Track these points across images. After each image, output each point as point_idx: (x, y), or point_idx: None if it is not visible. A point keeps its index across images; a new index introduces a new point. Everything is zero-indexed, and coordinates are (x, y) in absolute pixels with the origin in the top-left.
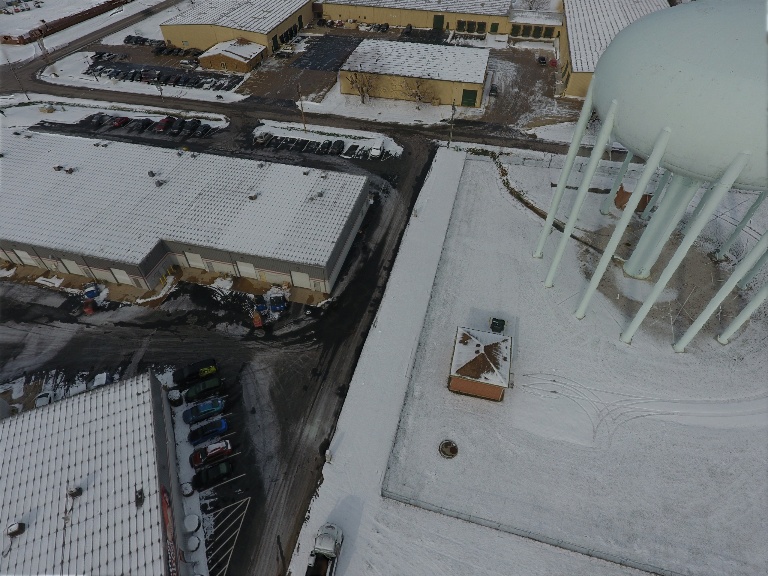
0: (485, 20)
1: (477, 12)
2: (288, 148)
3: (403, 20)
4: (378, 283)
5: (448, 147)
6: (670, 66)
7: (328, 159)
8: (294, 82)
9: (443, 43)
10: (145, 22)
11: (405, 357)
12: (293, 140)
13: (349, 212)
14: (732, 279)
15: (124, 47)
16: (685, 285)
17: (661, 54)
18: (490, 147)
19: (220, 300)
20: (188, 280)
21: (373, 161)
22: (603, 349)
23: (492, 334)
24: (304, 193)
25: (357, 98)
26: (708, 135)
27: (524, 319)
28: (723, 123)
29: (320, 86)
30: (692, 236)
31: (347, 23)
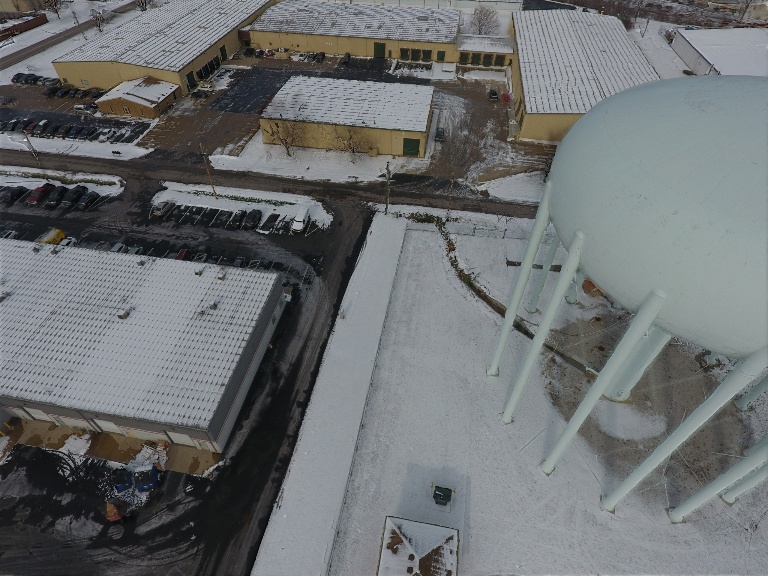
0: (430, 48)
1: (421, 39)
2: (192, 222)
3: (341, 48)
4: (288, 430)
5: (386, 213)
6: (659, 200)
7: (240, 236)
8: (210, 129)
9: (385, 75)
10: (44, 54)
11: (316, 561)
12: (200, 210)
13: (249, 332)
14: (749, 463)
15: (11, 87)
16: (674, 408)
17: (644, 178)
18: (435, 211)
19: (68, 475)
20: (28, 442)
21: (295, 237)
22: (580, 525)
23: (432, 528)
24: (193, 304)
25: (282, 149)
26: (723, 311)
27: (477, 479)
28: (746, 298)
29: (240, 134)
30: (697, 422)
31: (278, 53)
